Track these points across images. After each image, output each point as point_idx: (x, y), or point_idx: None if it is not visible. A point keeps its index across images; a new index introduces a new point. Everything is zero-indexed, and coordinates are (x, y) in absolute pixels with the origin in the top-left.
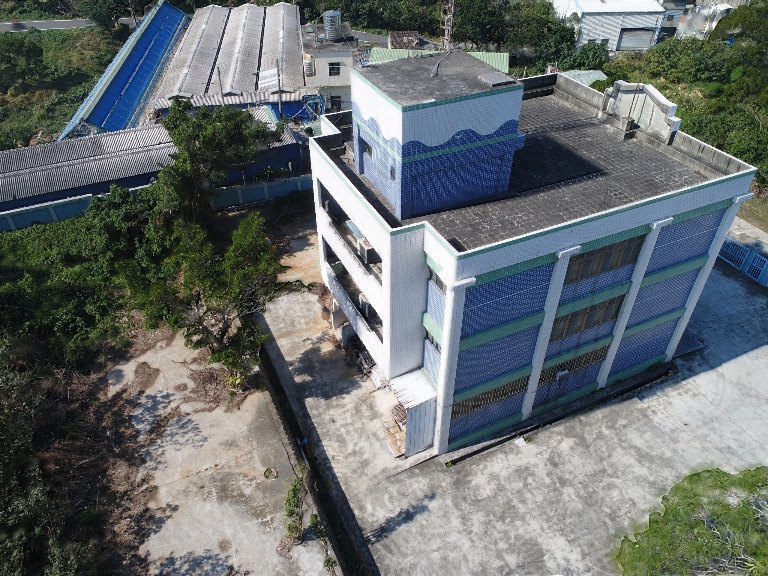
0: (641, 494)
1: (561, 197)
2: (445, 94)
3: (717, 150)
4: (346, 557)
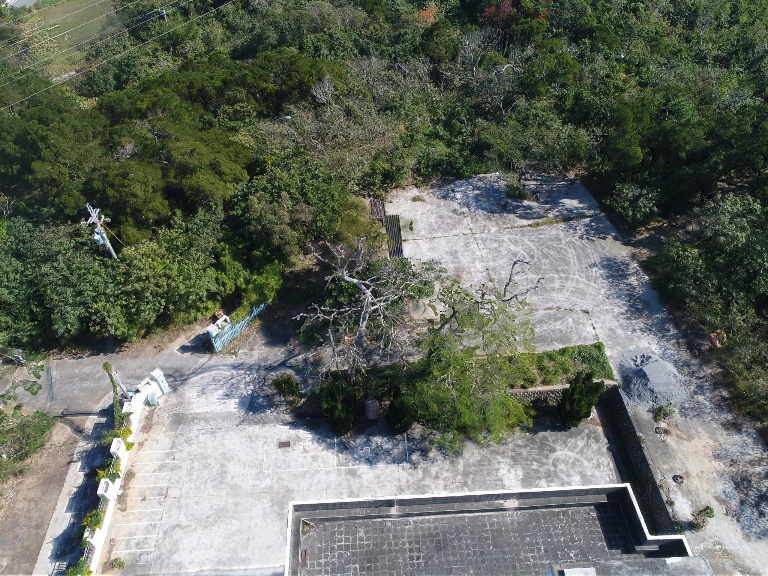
0: (437, 490)
1: (476, 575)
2: (653, 571)
3: (289, 549)
4: (654, 521)
